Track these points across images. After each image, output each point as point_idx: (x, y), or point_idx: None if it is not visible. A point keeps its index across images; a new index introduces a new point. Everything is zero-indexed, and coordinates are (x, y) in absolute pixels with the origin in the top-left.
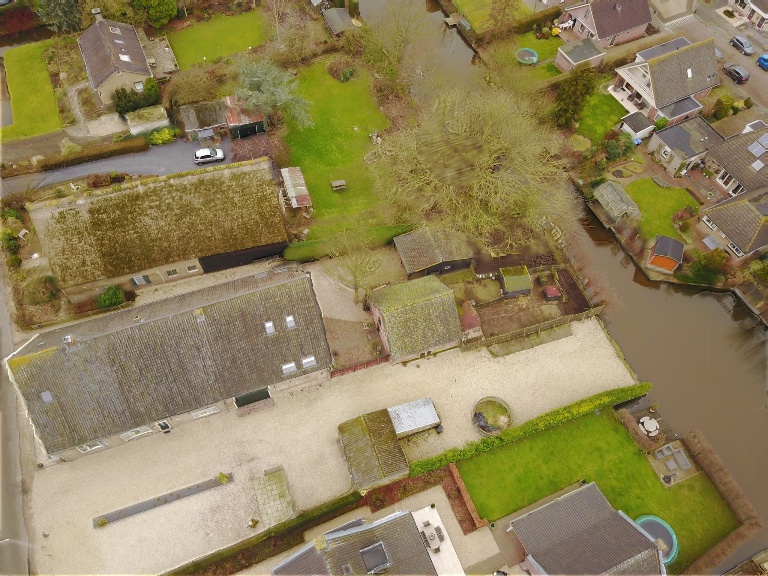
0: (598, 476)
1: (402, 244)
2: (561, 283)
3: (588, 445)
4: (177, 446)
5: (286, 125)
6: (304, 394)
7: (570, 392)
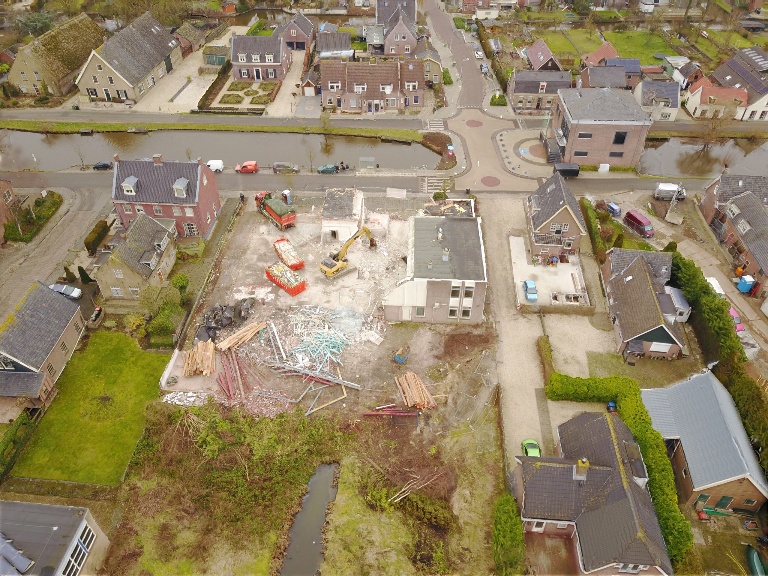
0: None
1: None
2: None
3: None
4: (164, 85)
5: None
6: None
7: None
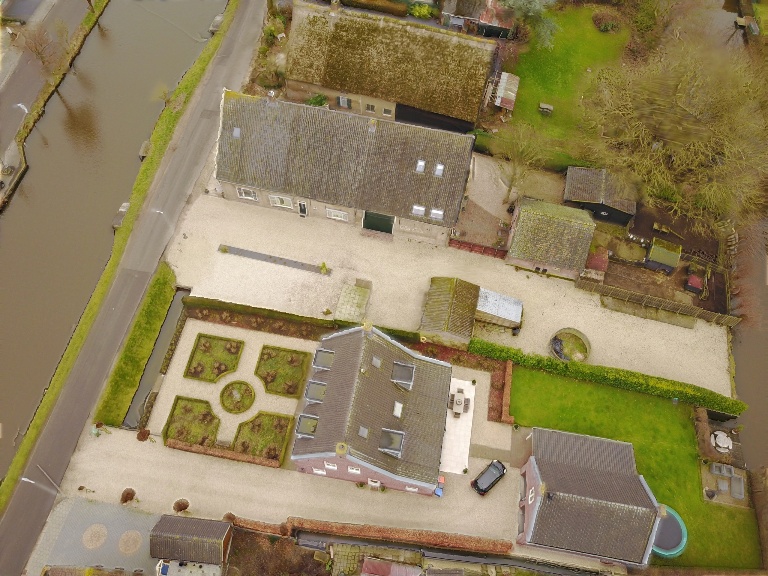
0: (641, 450)
1: (573, 174)
2: (710, 282)
3: (647, 421)
4: (304, 229)
5: (528, 39)
6: (420, 246)
7: (658, 372)
